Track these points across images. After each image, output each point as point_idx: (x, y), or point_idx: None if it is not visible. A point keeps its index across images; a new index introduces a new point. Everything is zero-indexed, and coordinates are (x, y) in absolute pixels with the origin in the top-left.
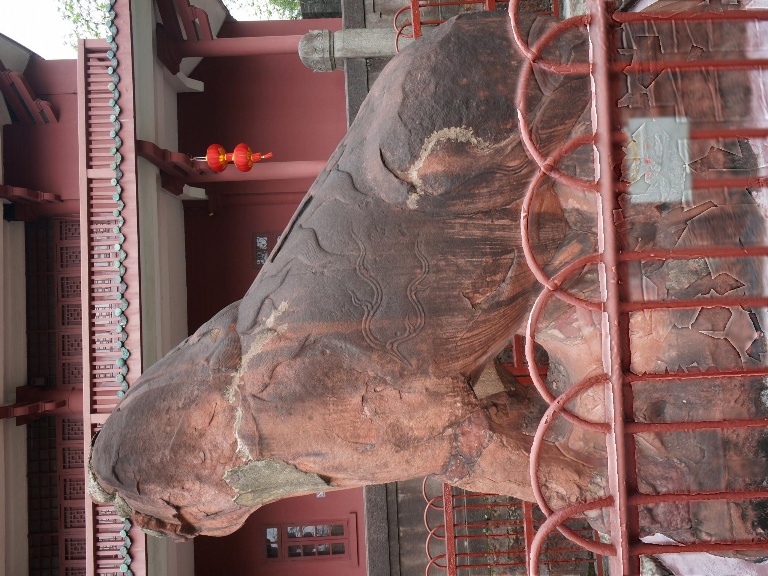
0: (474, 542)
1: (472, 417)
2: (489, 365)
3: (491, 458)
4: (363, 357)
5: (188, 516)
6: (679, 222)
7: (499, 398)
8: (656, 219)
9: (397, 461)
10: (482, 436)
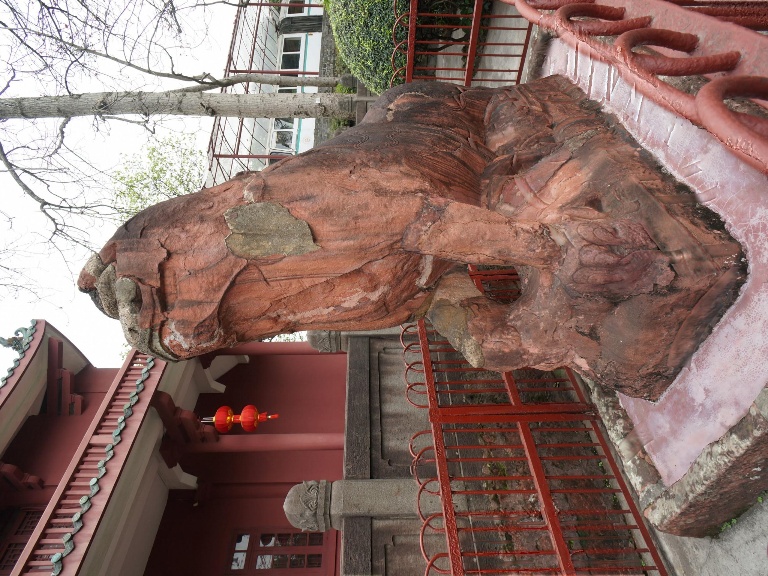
0: None
1: None
2: (465, 276)
3: (457, 206)
4: (353, 152)
5: (169, 281)
6: (564, 126)
7: (479, 300)
8: (551, 133)
9: (376, 204)
10: None
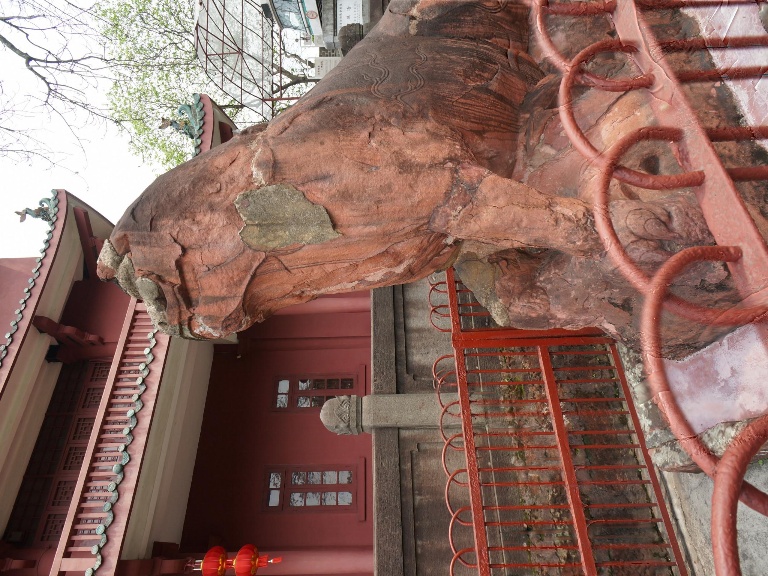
0: (513, 561)
1: (471, 163)
2: None
3: (492, 184)
4: (371, 103)
5: (189, 276)
6: None
7: (508, 253)
8: (611, 43)
9: (400, 184)
10: (482, 171)
